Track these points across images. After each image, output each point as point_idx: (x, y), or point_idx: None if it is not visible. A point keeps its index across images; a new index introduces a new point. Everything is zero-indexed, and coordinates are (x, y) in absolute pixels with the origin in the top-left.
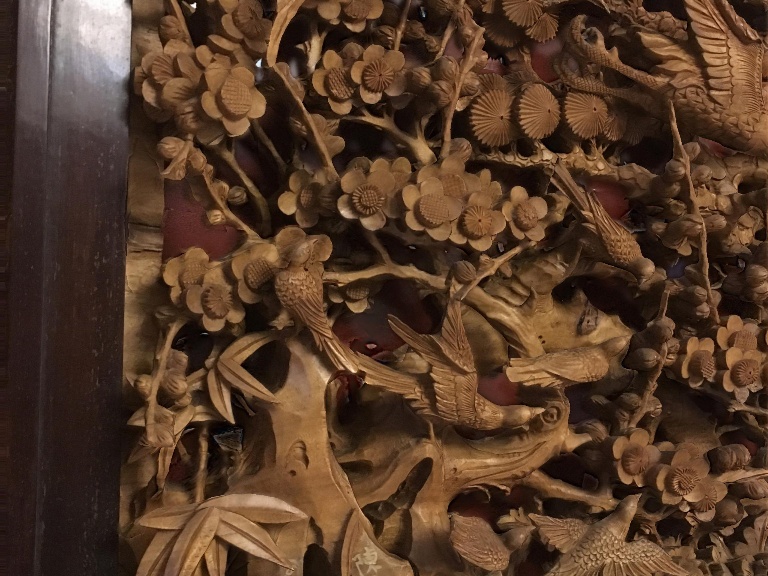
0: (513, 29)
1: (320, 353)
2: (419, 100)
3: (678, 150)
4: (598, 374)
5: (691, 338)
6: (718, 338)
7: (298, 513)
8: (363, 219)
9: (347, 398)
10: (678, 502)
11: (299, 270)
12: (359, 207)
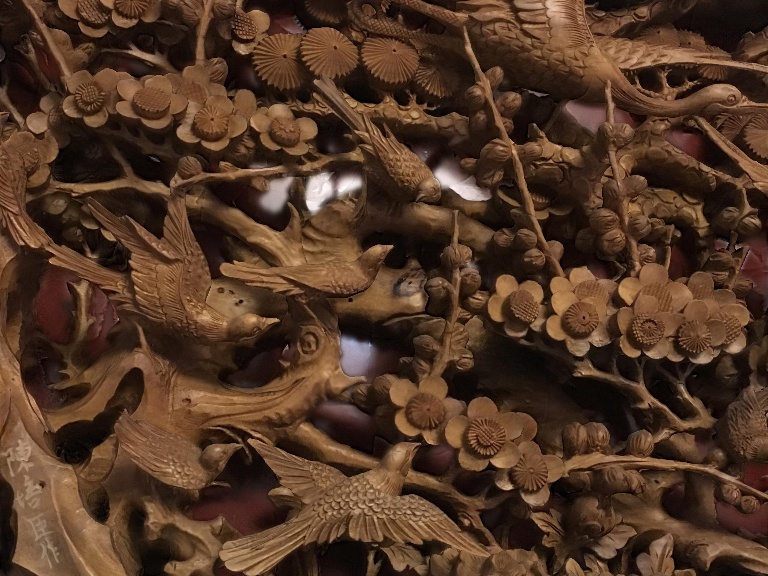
0: (335, 4)
1: (5, 231)
2: (190, 37)
3: (476, 74)
4: (348, 284)
5: (503, 275)
6: (553, 287)
7: None
8: (87, 117)
9: (97, 333)
10: (483, 467)
11: None
12: (81, 104)
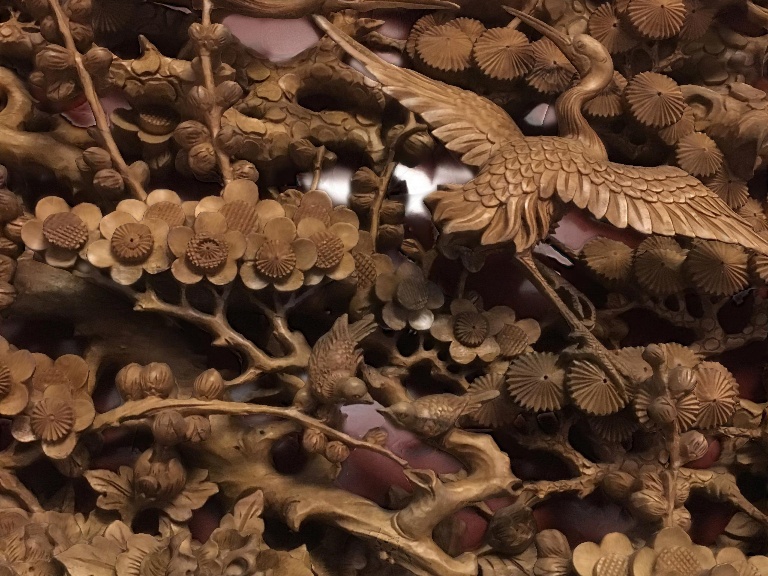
0: None
1: None
2: None
3: None
4: None
5: (48, 197)
6: None
7: None
8: None
9: None
10: None
11: None
12: None
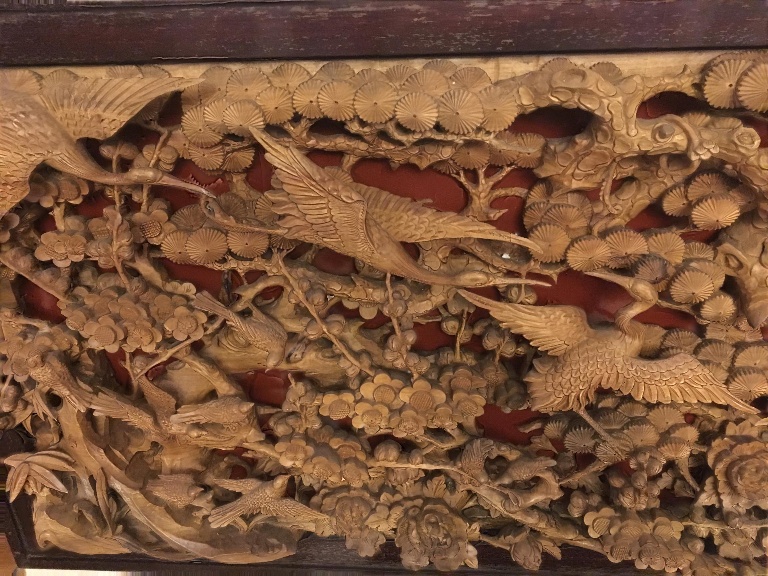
0: None
1: None
2: None
3: None
4: (235, 421)
5: (327, 394)
6: (362, 390)
7: (70, 468)
8: (80, 331)
9: None
10: (325, 479)
11: (35, 368)
12: (73, 327)
